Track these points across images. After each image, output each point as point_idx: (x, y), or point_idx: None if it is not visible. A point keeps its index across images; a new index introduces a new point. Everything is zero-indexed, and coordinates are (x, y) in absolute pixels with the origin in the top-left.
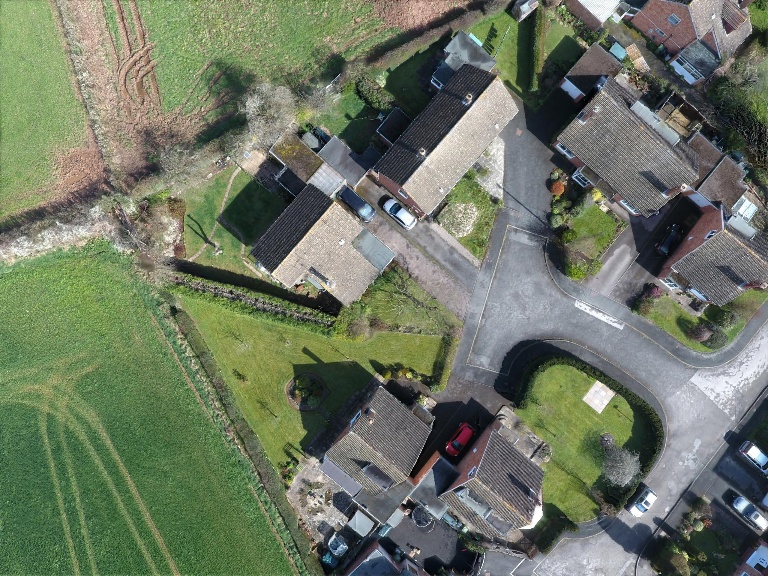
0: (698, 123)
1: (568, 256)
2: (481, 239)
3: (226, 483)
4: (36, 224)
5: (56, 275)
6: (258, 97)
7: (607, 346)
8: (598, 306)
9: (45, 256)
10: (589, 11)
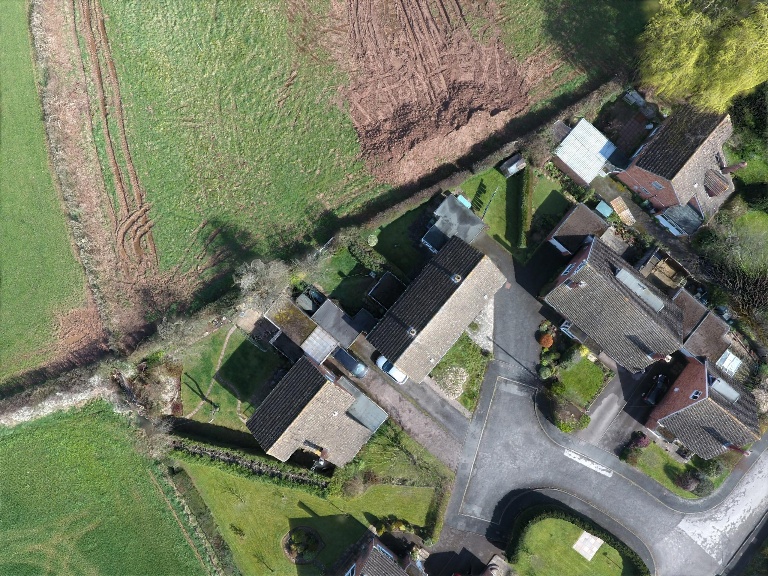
0: (683, 277)
1: (557, 412)
2: (472, 391)
3: None
4: (36, 390)
5: (56, 436)
6: (253, 276)
7: (596, 494)
8: (587, 454)
9: (45, 418)
10: (575, 172)
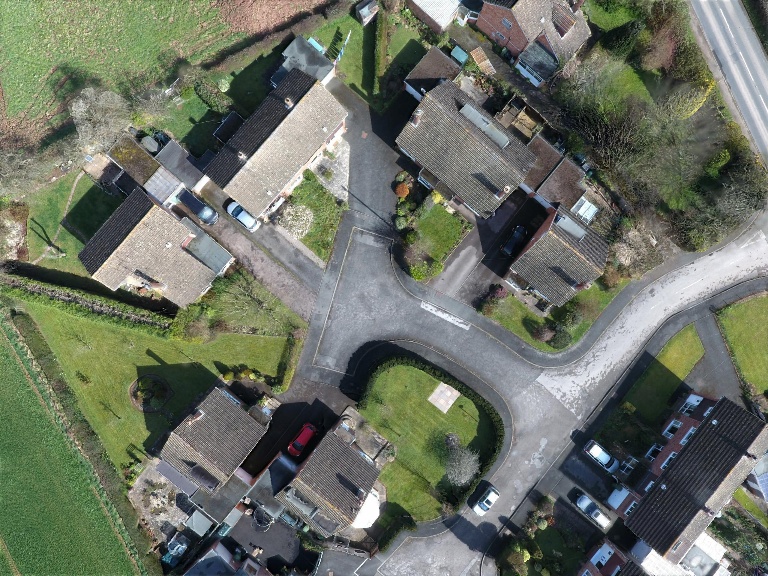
0: None
1: (407, 258)
2: (326, 241)
3: (67, 484)
4: None
5: None
6: (82, 102)
7: (453, 346)
8: (444, 307)
9: None
10: (428, 15)
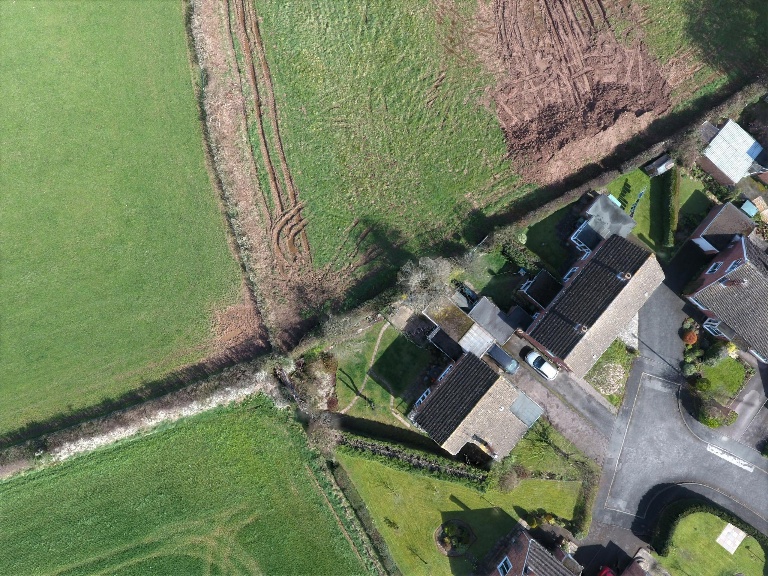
0: None
1: (706, 408)
2: None
3: None
4: (201, 385)
5: (216, 430)
6: (424, 274)
7: (738, 488)
8: (729, 450)
9: (206, 412)
10: (723, 172)
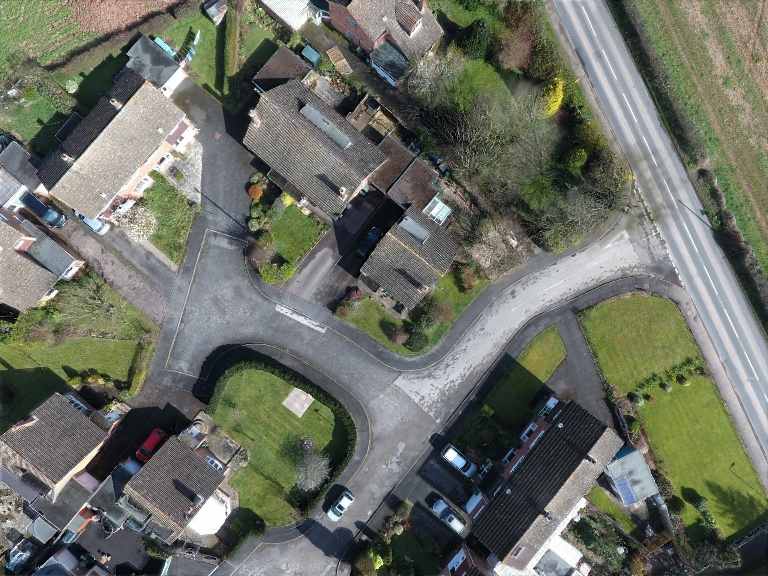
0: None
1: (255, 260)
2: (178, 243)
3: None
4: None
5: None
6: None
7: (309, 350)
8: (300, 310)
9: None
10: None
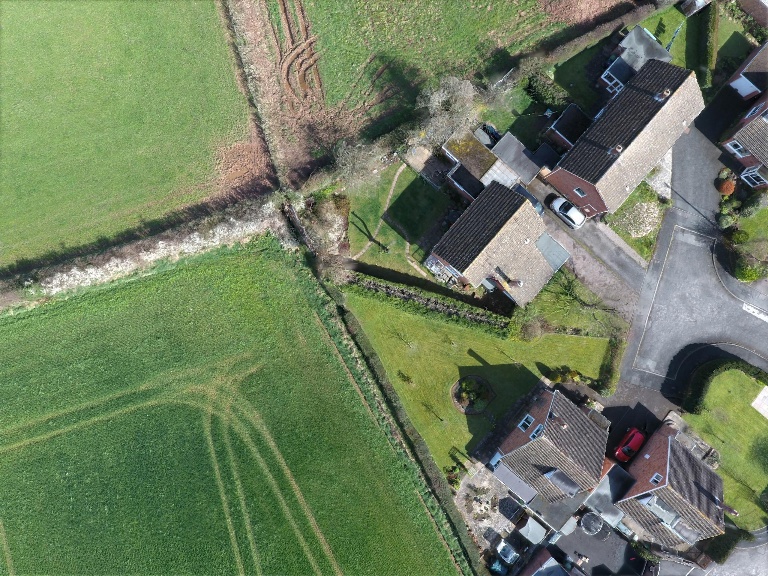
0: None
1: (744, 258)
2: (649, 239)
3: (392, 488)
4: (204, 220)
5: (220, 272)
6: (446, 91)
7: None
8: (766, 309)
9: (209, 253)
10: (766, 6)
